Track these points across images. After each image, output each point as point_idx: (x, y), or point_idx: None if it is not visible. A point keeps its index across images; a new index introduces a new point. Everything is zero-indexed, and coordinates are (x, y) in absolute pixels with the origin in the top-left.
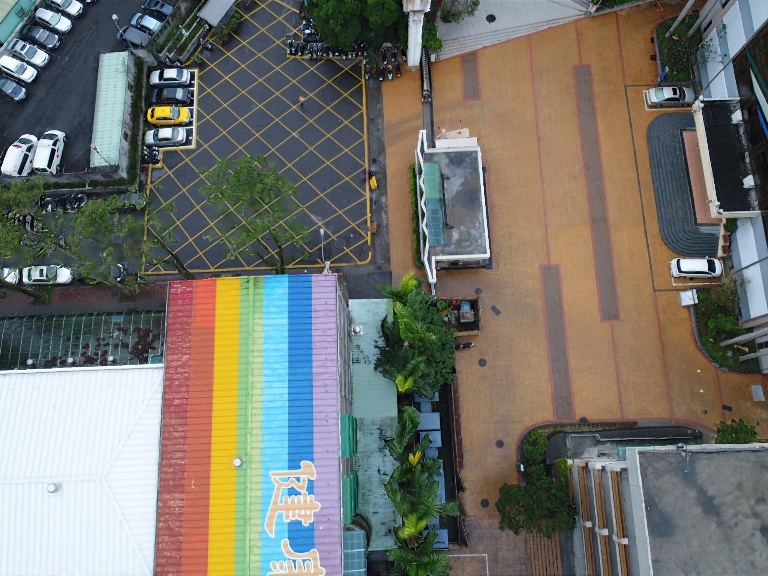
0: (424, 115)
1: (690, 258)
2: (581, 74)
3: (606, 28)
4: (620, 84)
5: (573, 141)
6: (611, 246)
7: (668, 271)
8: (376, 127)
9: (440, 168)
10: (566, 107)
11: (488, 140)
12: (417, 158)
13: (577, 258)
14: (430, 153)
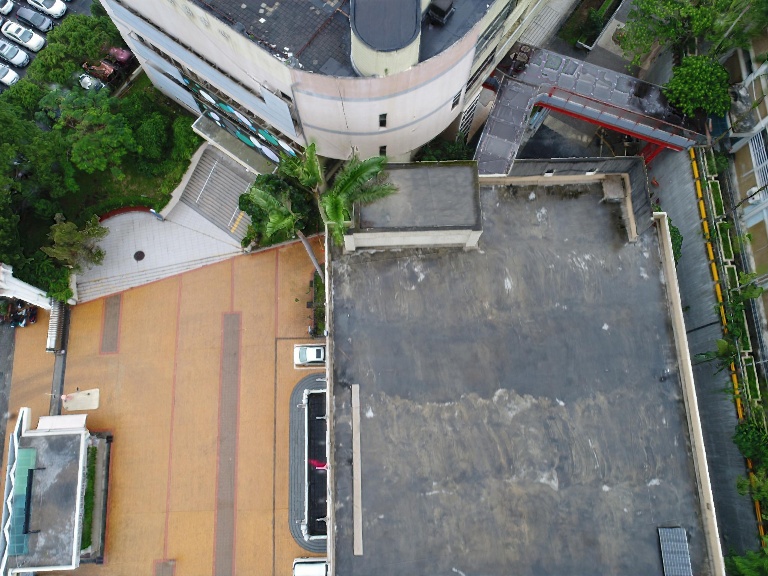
0: (55, 370)
1: (307, 563)
2: (230, 323)
3: (264, 268)
4: (271, 336)
5: (210, 406)
6: (234, 538)
7: (291, 570)
8: (2, 383)
9: (37, 455)
10: (208, 364)
11: (119, 403)
12: (12, 443)
13: (195, 552)
14: (28, 436)
